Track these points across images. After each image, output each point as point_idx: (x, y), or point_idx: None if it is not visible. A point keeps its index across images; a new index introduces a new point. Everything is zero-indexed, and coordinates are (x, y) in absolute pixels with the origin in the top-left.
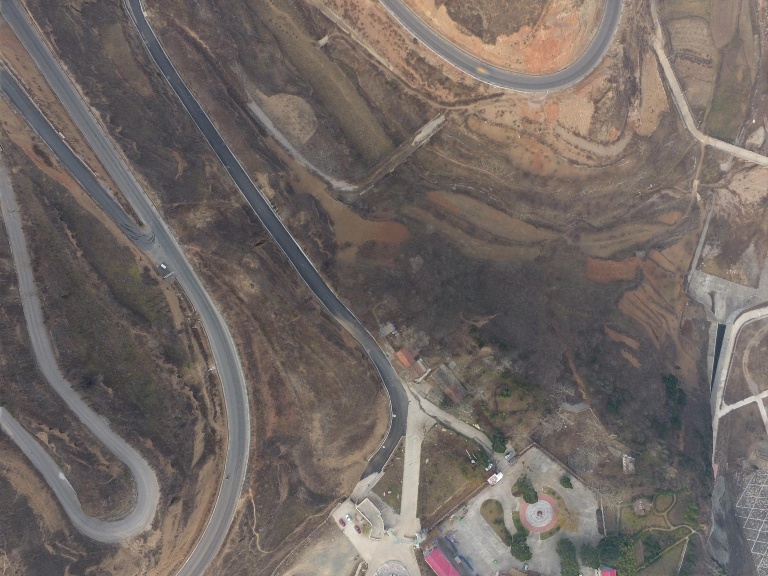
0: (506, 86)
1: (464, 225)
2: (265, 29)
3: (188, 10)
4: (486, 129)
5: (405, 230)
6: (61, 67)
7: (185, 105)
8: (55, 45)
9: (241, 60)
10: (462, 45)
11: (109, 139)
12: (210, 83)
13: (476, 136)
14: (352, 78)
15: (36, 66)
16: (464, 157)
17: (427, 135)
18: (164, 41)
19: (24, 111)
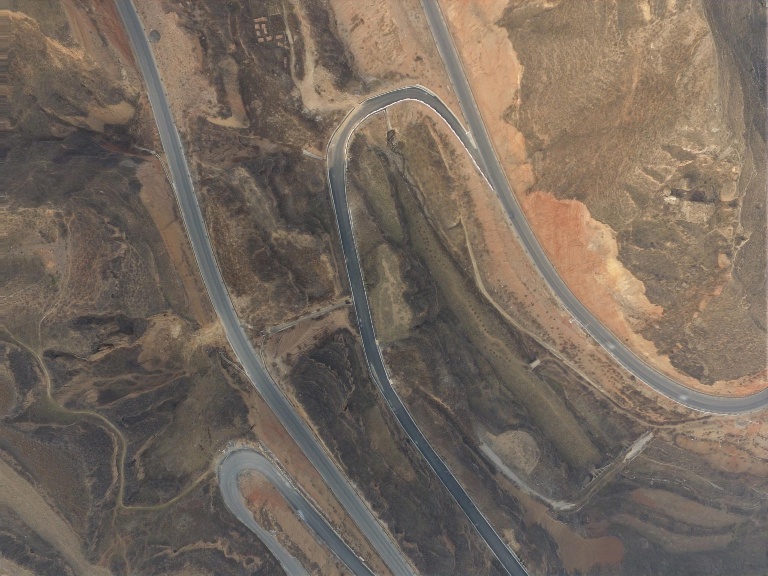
0: (715, 411)
1: (664, 521)
2: (483, 360)
3: (430, 375)
4: (692, 445)
5: (621, 544)
6: (346, 480)
7: (433, 468)
8: (342, 463)
9: (469, 401)
10: (675, 377)
11: (394, 545)
12: (455, 445)
13: (681, 449)
14: (560, 393)
15: (323, 480)
16: (665, 460)
17: (637, 452)
18: (413, 410)
19: (328, 541)
